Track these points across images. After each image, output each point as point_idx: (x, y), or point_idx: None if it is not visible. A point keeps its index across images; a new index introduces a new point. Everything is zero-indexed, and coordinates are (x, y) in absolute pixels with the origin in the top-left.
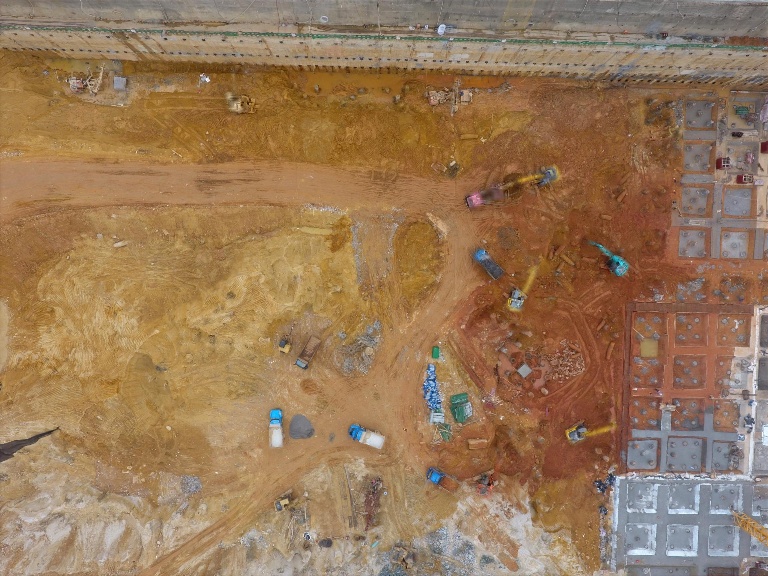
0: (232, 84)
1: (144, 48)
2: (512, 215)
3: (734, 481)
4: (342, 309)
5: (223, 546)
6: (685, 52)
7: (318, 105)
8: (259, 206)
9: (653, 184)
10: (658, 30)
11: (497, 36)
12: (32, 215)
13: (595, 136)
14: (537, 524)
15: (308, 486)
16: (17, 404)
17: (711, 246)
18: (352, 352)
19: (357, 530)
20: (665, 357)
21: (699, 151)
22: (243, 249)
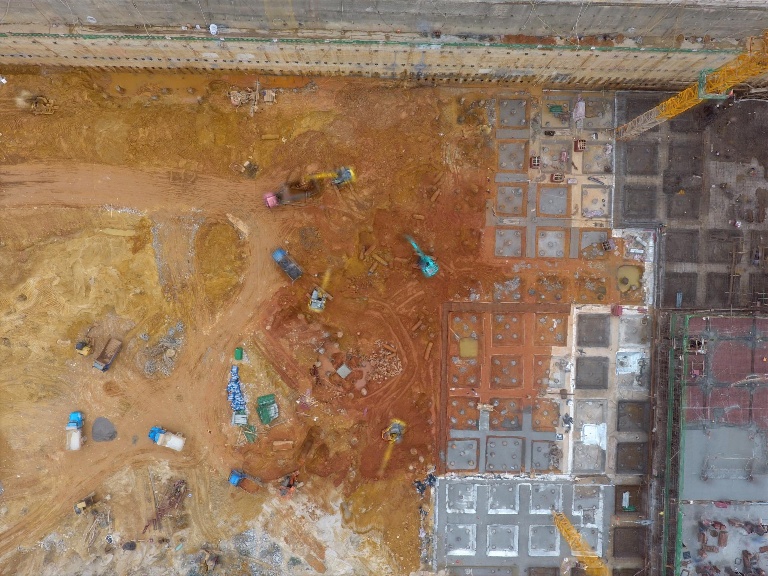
0: (29, 85)
1: None
2: (313, 215)
3: (554, 481)
4: (145, 311)
5: (22, 550)
6: (462, 51)
7: (120, 106)
8: (54, 208)
9: (466, 183)
10: (430, 29)
11: (271, 36)
12: None
13: (396, 136)
14: (348, 525)
15: (112, 489)
16: None
17: (526, 245)
18: (154, 354)
19: (162, 533)
20: (482, 357)
21: (514, 150)
22: (44, 251)
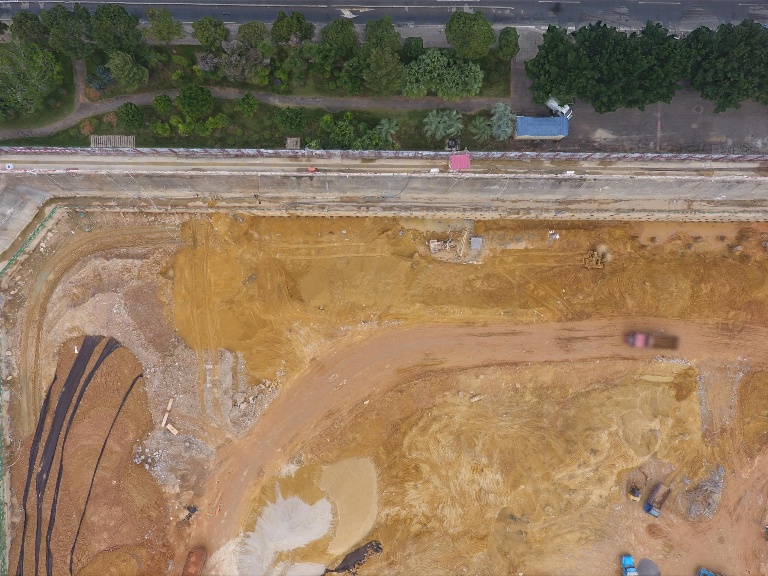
0: (581, 240)
1: (516, 216)
2: None
3: None
4: (684, 455)
5: None
6: None
7: None
8: (614, 361)
9: None
10: None
11: None
12: (411, 381)
13: None
14: None
15: None
16: (399, 564)
17: None
18: (698, 498)
19: None
20: None
21: None
22: (589, 399)
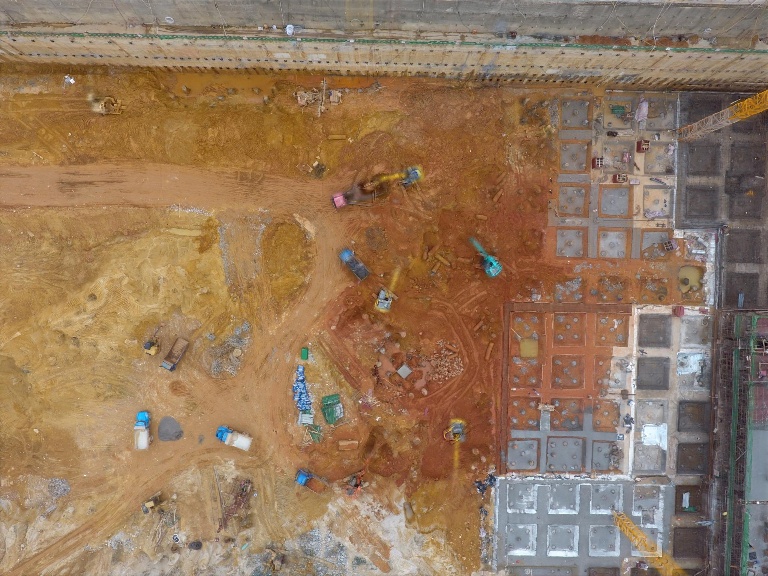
0: (97, 85)
1: None
2: (380, 215)
3: (614, 481)
4: (211, 310)
5: (89, 549)
6: (537, 51)
7: (186, 106)
8: (123, 208)
9: (528, 184)
10: (506, 29)
11: (346, 36)
12: None
13: (462, 136)
14: (411, 525)
15: (178, 488)
16: None
17: (588, 246)
18: (220, 354)
19: (227, 532)
20: (544, 357)
21: (576, 150)
22: (111, 251)
